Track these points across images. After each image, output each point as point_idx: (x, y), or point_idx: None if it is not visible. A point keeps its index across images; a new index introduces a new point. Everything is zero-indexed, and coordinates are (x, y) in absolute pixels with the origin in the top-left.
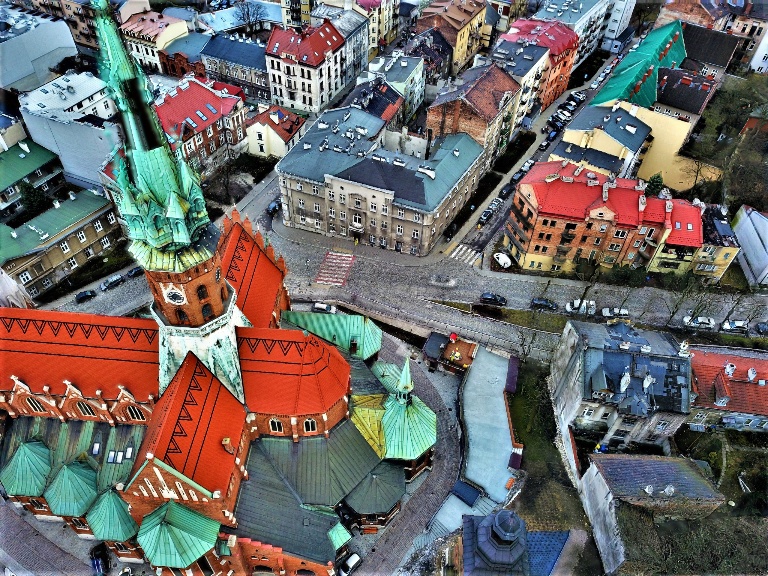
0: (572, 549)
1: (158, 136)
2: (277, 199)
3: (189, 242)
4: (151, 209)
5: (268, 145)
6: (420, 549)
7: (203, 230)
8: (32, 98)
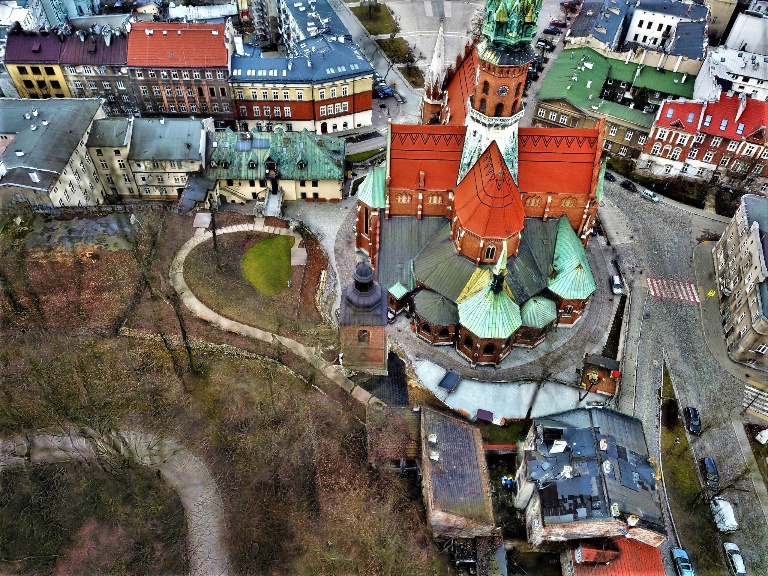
0: None
1: None
2: None
3: (492, 41)
4: (492, 5)
5: None
6: None
7: (507, 46)
8: (726, 52)
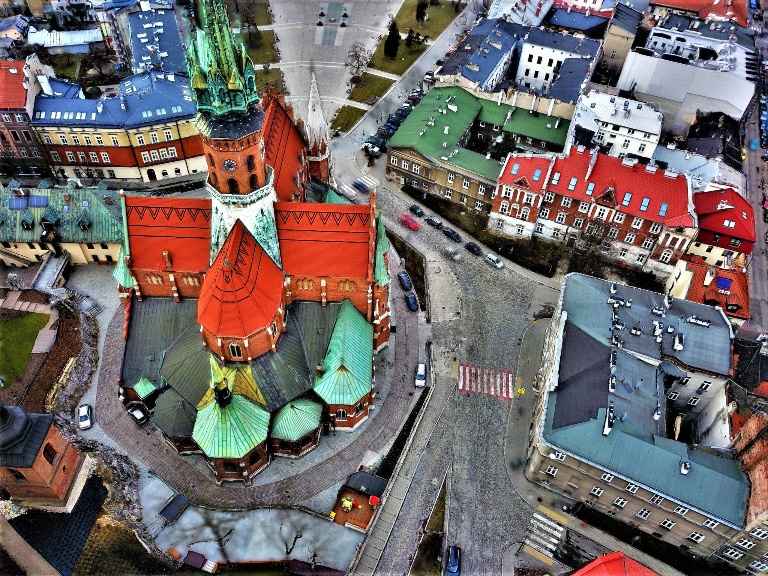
0: (46, 574)
1: (202, 22)
2: None
3: None
4: None
5: (679, 292)
6: (134, 468)
7: (216, 116)
8: (598, 97)
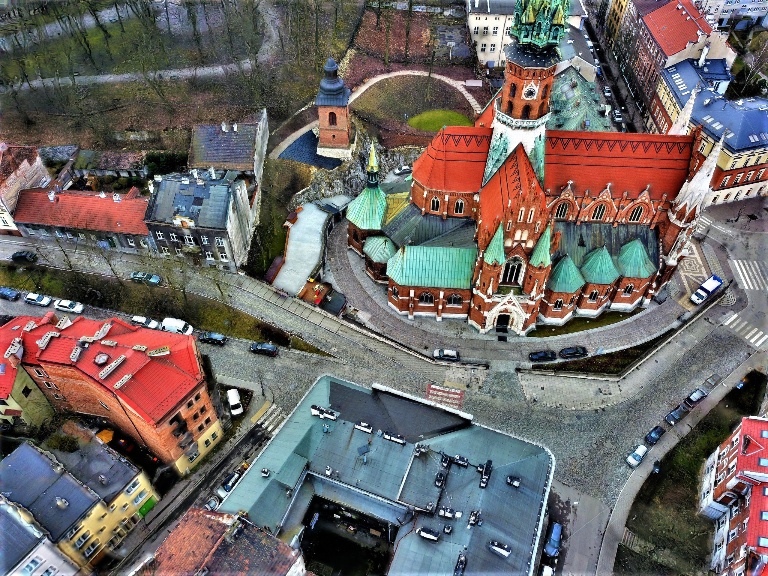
0: (281, 148)
1: None
2: (558, 567)
3: None
4: None
5: None
6: None
7: None
8: None
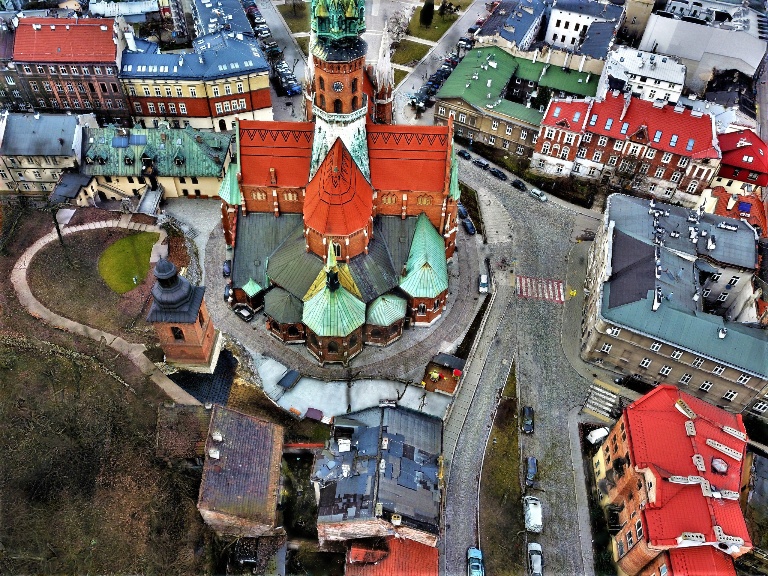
0: None
1: None
2: None
3: (317, 36)
4: None
5: None
6: None
7: (332, 41)
8: (626, 52)
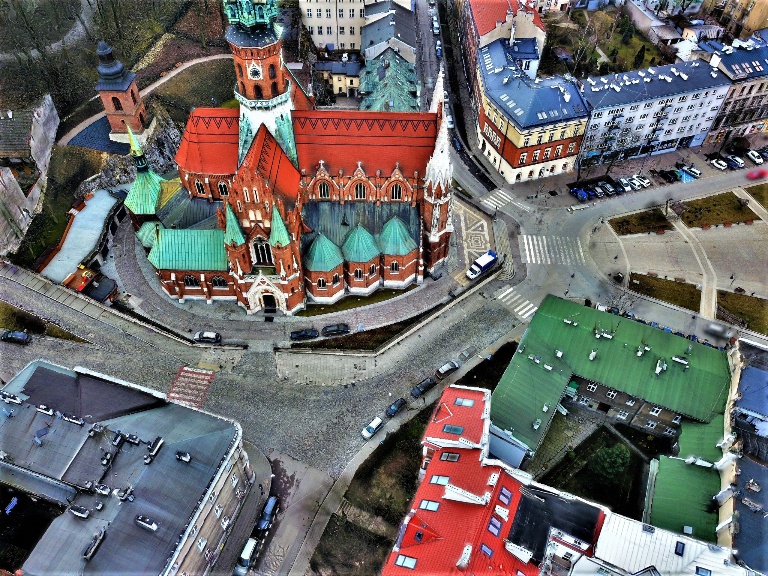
0: (71, 135)
1: None
2: (267, 538)
3: None
4: None
5: None
6: None
7: None
8: None
